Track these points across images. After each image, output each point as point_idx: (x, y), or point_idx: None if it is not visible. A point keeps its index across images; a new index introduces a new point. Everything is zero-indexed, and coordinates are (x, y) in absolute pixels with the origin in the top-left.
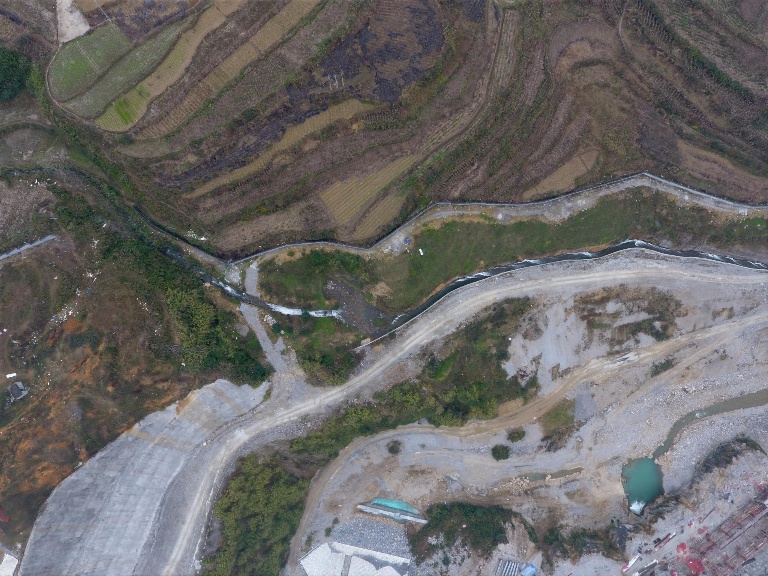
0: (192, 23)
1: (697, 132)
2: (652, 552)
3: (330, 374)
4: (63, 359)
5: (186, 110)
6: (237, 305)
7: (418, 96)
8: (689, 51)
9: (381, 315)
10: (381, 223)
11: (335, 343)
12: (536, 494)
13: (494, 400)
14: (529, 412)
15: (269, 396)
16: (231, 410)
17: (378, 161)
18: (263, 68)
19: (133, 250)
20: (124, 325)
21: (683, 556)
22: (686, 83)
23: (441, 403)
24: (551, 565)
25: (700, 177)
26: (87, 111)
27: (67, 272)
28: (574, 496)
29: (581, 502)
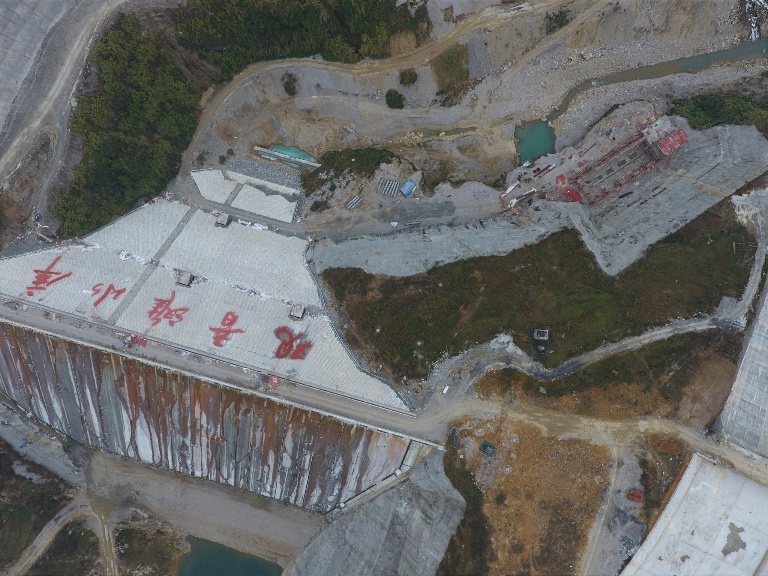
0: None
1: None
2: (531, 181)
3: None
4: None
5: None
6: None
7: None
8: None
9: None
10: None
11: None
12: (429, 147)
13: (382, 24)
14: (422, 54)
15: None
16: None
17: None
18: None
19: None
20: None
21: (562, 187)
22: None
23: (327, 12)
24: (432, 191)
25: None
26: None
27: None
28: (466, 151)
29: (473, 157)
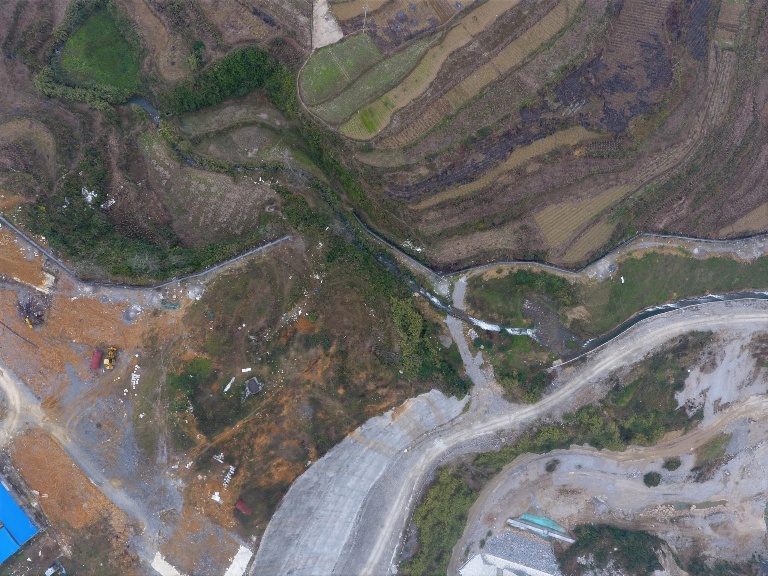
0: (440, 40)
1: None
2: None
3: (525, 392)
4: (297, 358)
5: (425, 124)
6: (444, 317)
7: (641, 128)
8: None
9: (573, 338)
10: (590, 249)
11: (529, 361)
12: (681, 523)
13: (662, 429)
14: (687, 442)
15: (468, 409)
16: (434, 420)
17: (593, 188)
18: (501, 89)
19: (358, 256)
20: (354, 329)
21: None
22: None
23: None
24: None
25: None
26: (334, 117)
27: (298, 272)
28: (718, 528)
29: (724, 534)
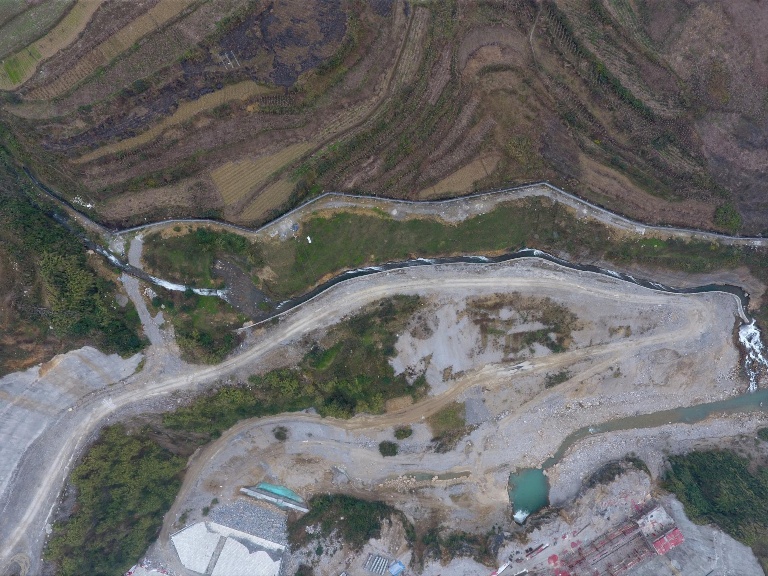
0: None
1: (599, 147)
2: (523, 561)
3: (206, 352)
4: None
5: (77, 75)
6: (118, 275)
7: (316, 84)
8: (595, 65)
9: (266, 299)
10: (269, 207)
11: (216, 322)
12: (421, 494)
13: (379, 395)
14: (418, 411)
15: (141, 368)
16: (100, 378)
17: (272, 145)
18: (159, 41)
19: (13, 210)
20: None
21: (554, 568)
22: (591, 97)
23: (322, 393)
24: (422, 564)
25: (599, 192)
26: None
27: None
28: (458, 499)
29: (465, 506)
